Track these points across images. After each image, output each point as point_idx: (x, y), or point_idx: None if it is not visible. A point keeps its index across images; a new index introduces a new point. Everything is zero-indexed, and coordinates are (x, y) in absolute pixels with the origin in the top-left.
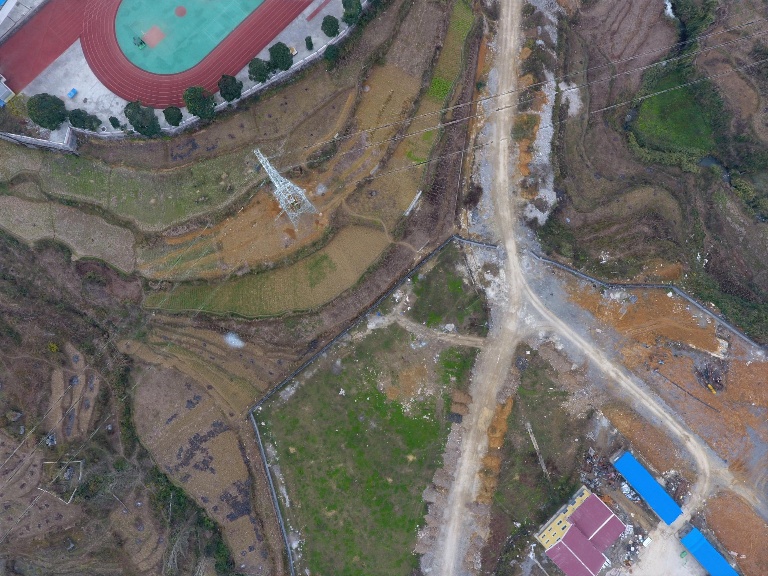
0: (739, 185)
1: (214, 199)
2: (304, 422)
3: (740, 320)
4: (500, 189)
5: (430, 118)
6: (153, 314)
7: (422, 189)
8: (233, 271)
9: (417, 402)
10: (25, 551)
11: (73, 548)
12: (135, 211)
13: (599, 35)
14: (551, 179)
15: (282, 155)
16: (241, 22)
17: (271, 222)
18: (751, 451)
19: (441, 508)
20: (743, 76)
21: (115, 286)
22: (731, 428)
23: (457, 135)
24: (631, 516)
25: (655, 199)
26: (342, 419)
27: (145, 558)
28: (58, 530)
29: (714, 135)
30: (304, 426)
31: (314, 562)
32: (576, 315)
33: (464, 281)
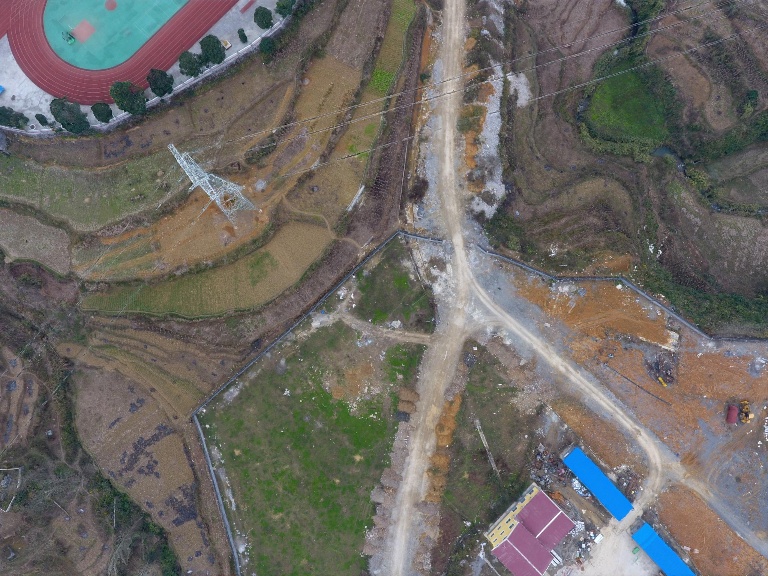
0: (693, 175)
1: (150, 197)
2: (249, 424)
3: (691, 311)
4: (446, 182)
5: (372, 111)
6: (91, 316)
7: (365, 184)
8: (171, 271)
9: (363, 401)
10: None
11: (14, 557)
12: (69, 211)
13: (548, 24)
14: (499, 171)
15: (219, 151)
16: (173, 15)
17: (210, 220)
18: (703, 444)
19: (389, 508)
20: (694, 64)
21: (51, 288)
22: (682, 421)
23: (400, 128)
24: (582, 512)
25: (605, 190)
26: (287, 420)
27: (90, 566)
28: None
29: (667, 124)
30: (249, 428)
31: (261, 566)
32: (524, 309)
33: (410, 277)
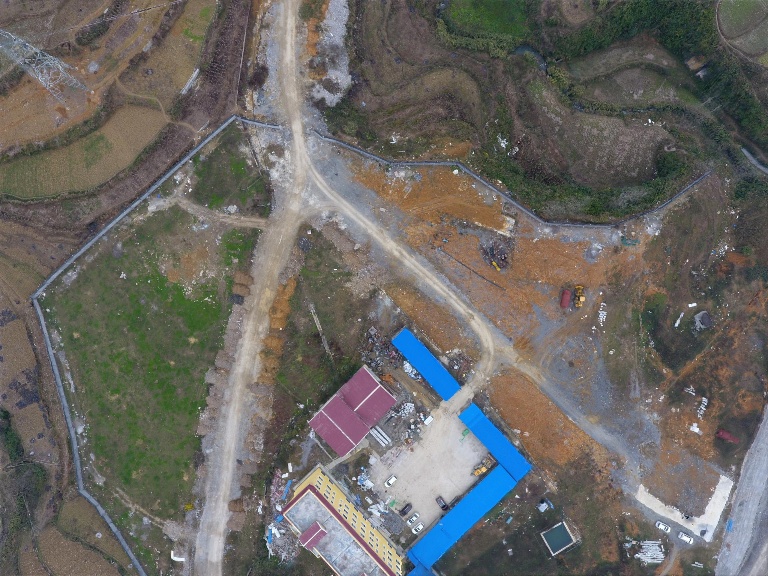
0: (554, 73)
1: None
2: (87, 307)
3: (530, 198)
4: (287, 70)
5: None
6: None
7: (199, 67)
8: (4, 151)
9: (199, 284)
10: None
11: None
12: None
13: None
14: (345, 62)
15: (50, 31)
16: None
17: (42, 101)
18: (537, 329)
19: (221, 389)
20: None
21: None
22: (516, 306)
23: (238, 13)
24: (413, 395)
25: (453, 81)
26: (123, 303)
27: None
28: None
29: (528, 22)
30: (87, 311)
31: (98, 446)
32: (360, 194)
33: (248, 162)
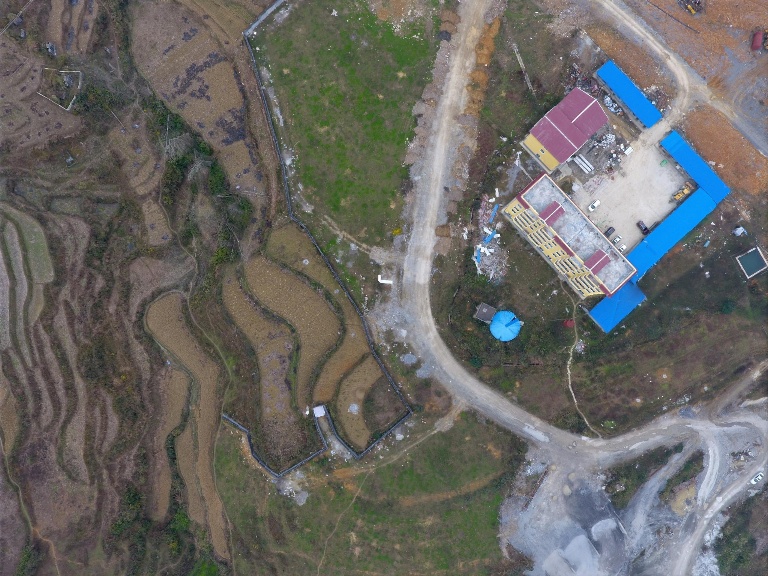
0: None
1: None
2: (297, 44)
3: None
4: None
5: None
6: None
7: None
8: None
9: (407, 23)
10: (25, 163)
11: (72, 162)
12: None
13: None
14: None
15: None
16: None
17: None
18: (729, 69)
19: (430, 120)
20: None
21: None
22: (710, 47)
23: None
24: (613, 128)
25: None
26: (334, 39)
27: (142, 182)
28: (58, 137)
29: None
30: (297, 48)
31: (307, 176)
32: None
33: None
